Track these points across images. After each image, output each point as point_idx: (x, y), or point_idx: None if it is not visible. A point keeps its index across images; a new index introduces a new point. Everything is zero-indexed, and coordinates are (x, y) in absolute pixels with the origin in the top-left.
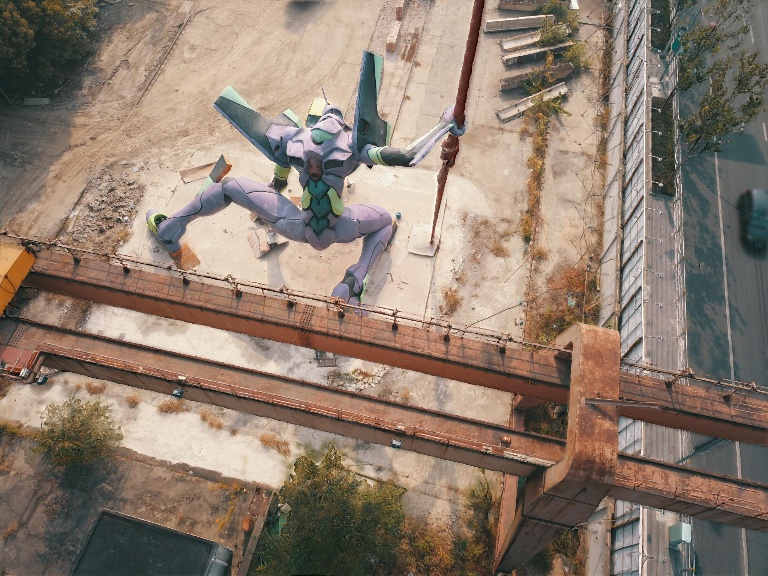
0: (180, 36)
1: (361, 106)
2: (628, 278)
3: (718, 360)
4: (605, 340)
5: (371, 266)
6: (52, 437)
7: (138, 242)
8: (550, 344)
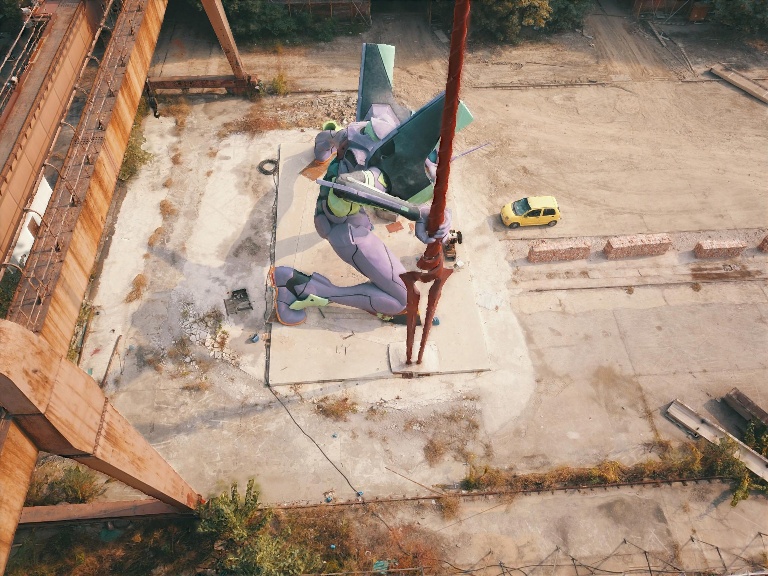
0: (578, 86)
1: (403, 131)
2: None
3: None
4: None
5: (357, 313)
6: None
7: None
8: None
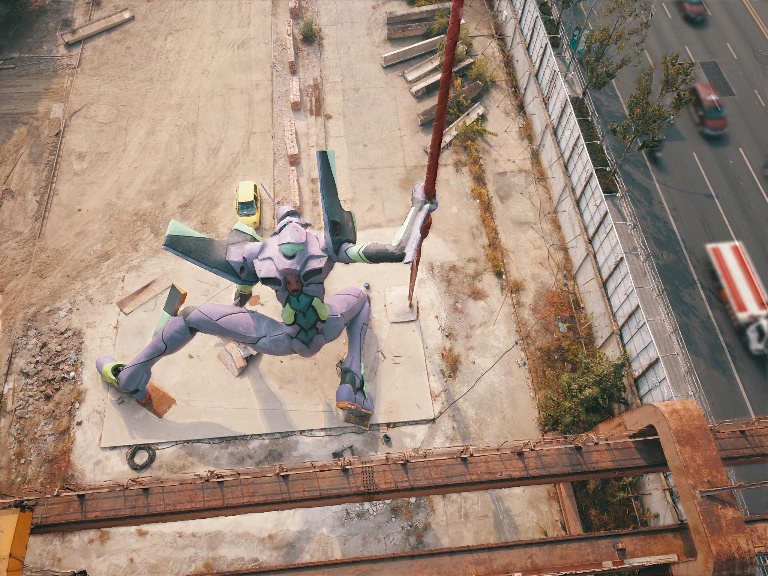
0: (62, 146)
1: (327, 208)
2: (616, 294)
3: (711, 344)
4: (690, 419)
5: None
6: None
7: (96, 398)
8: (615, 420)
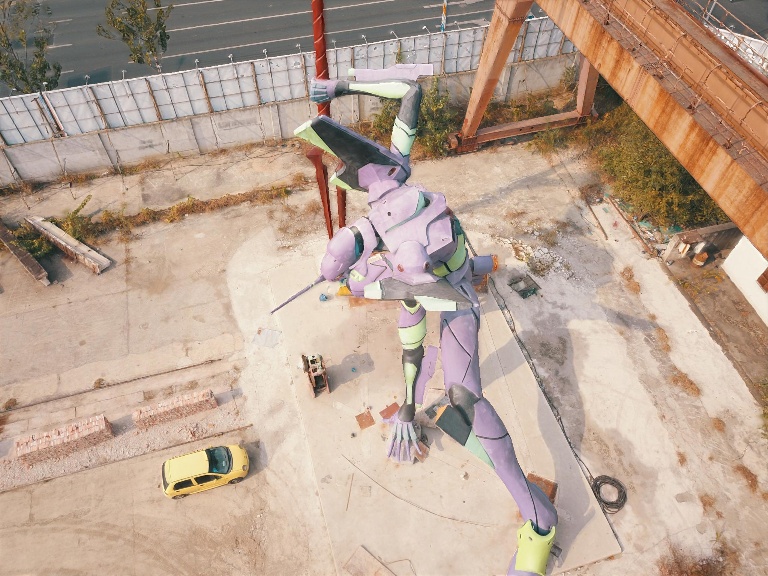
0: None
1: None
2: None
3: None
4: None
5: None
6: None
7: None
8: None
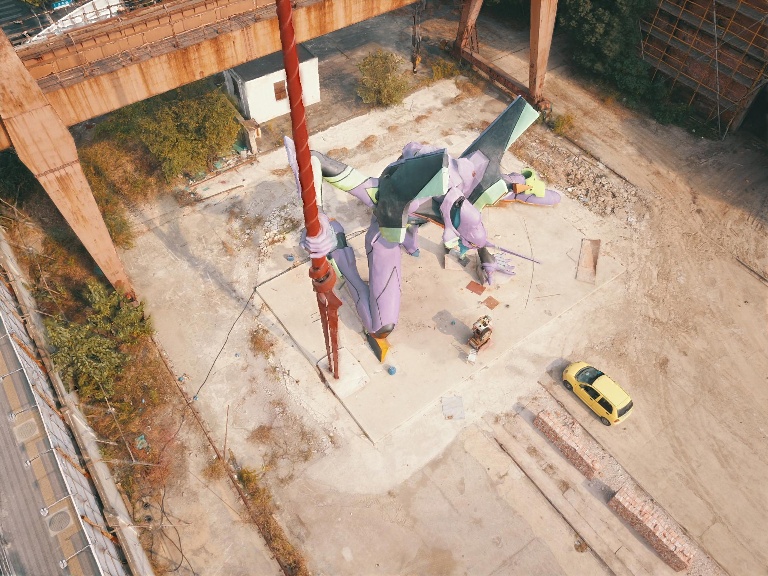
0: None
1: (407, 164)
2: None
3: None
4: None
5: None
6: (382, 58)
7: None
8: None
